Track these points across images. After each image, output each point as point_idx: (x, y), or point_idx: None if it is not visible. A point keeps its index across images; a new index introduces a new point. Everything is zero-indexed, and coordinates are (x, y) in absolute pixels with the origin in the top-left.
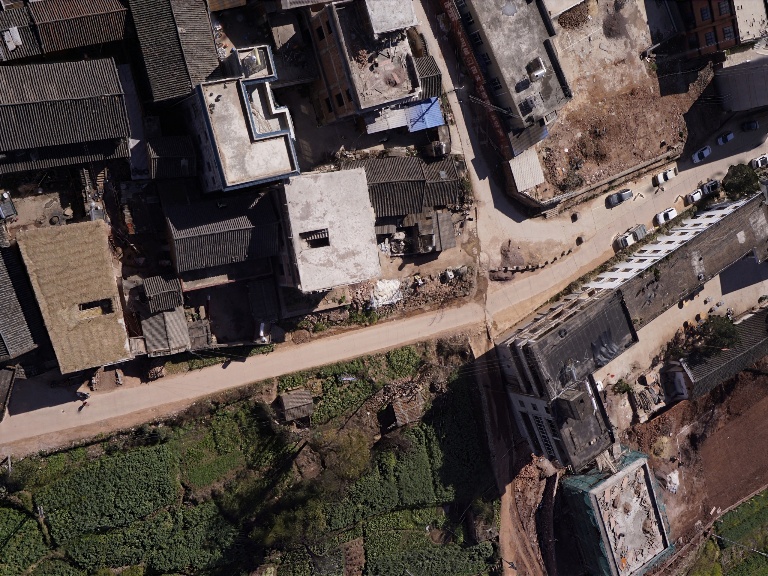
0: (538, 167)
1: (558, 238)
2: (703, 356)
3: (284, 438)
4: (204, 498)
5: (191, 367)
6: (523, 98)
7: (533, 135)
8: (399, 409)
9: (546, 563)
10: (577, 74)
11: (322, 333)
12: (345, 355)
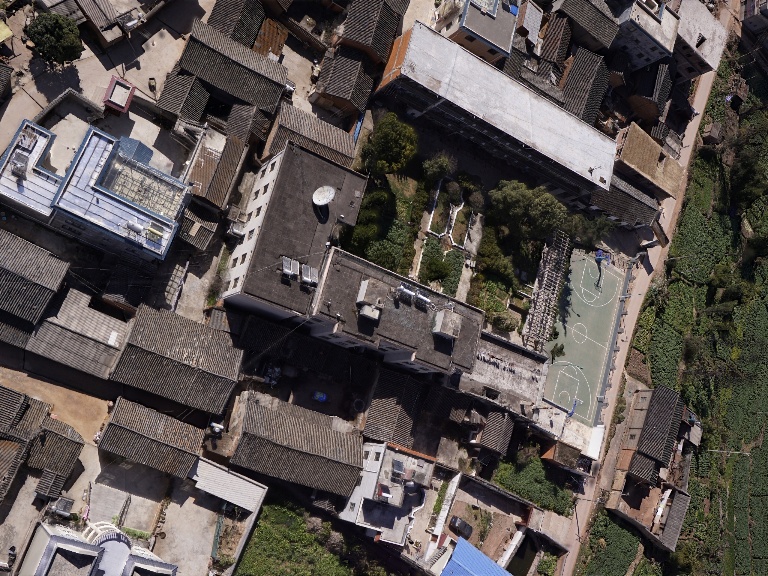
0: None
1: None
2: None
3: None
4: None
5: None
6: None
7: None
8: (740, 94)
9: None
10: None
11: (694, 91)
12: (707, 92)
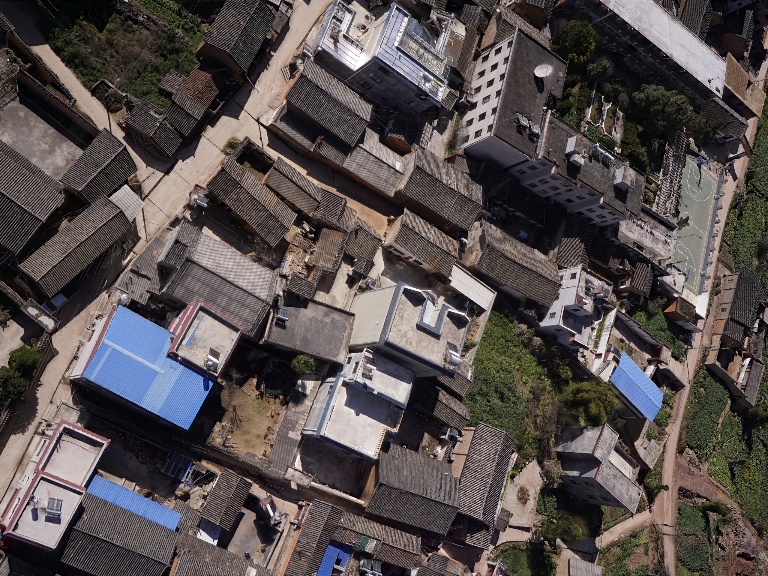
0: None
1: None
2: None
3: None
4: None
5: None
6: None
7: None
8: None
9: None
10: None
11: (763, 39)
12: None
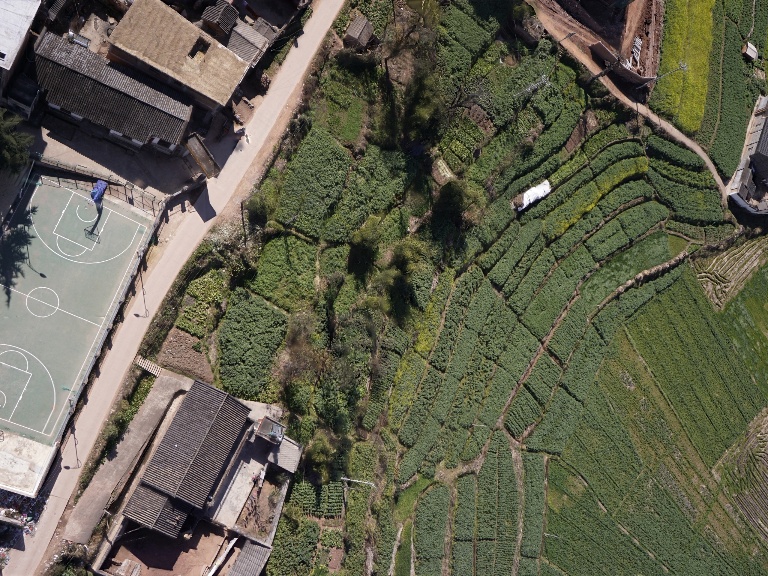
0: None
1: None
2: None
3: (372, 65)
4: (364, 145)
5: (279, 62)
6: None
7: None
8: None
9: (586, 25)
10: None
11: None
12: None
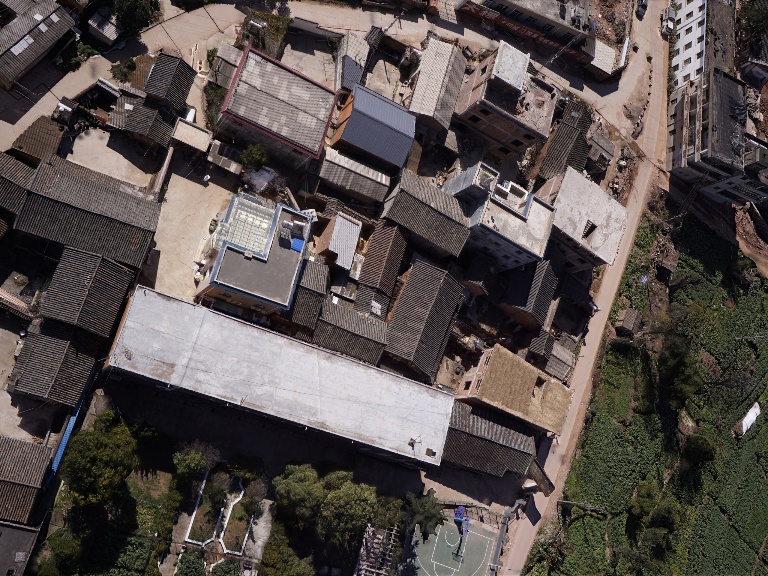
0: (605, 47)
1: (640, 72)
2: (757, 43)
3: None
4: (632, 417)
5: None
6: (569, 19)
7: (590, 33)
8: (667, 264)
9: None
10: None
11: (601, 271)
12: (621, 269)
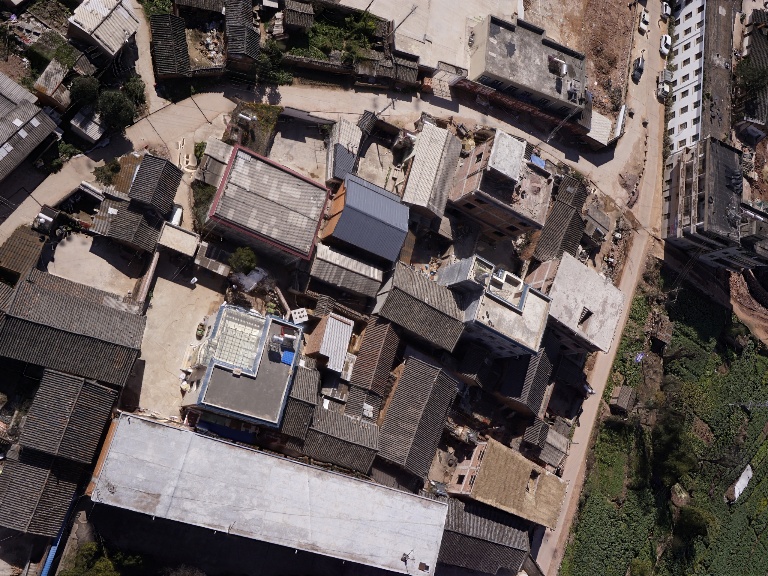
0: (601, 118)
1: (635, 138)
2: (753, 101)
3: None
4: (626, 494)
5: None
6: (566, 92)
7: (587, 105)
8: (662, 336)
9: None
10: (558, 29)
11: None
12: (615, 344)
